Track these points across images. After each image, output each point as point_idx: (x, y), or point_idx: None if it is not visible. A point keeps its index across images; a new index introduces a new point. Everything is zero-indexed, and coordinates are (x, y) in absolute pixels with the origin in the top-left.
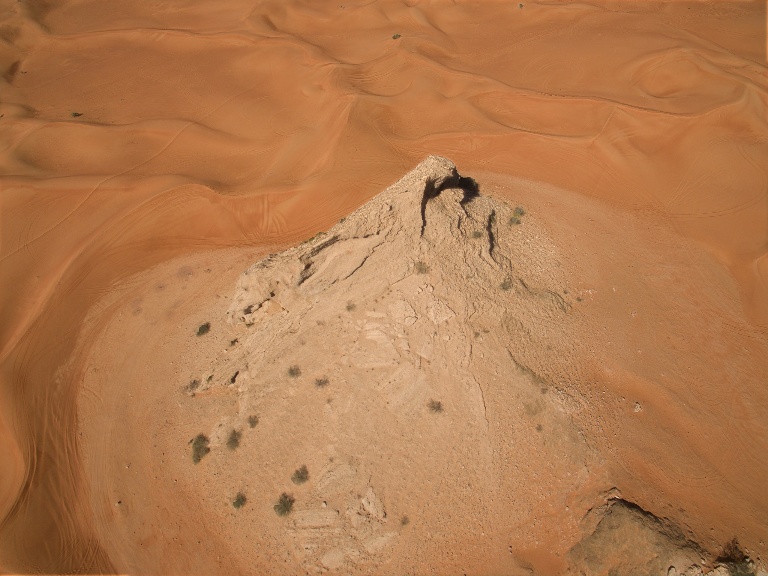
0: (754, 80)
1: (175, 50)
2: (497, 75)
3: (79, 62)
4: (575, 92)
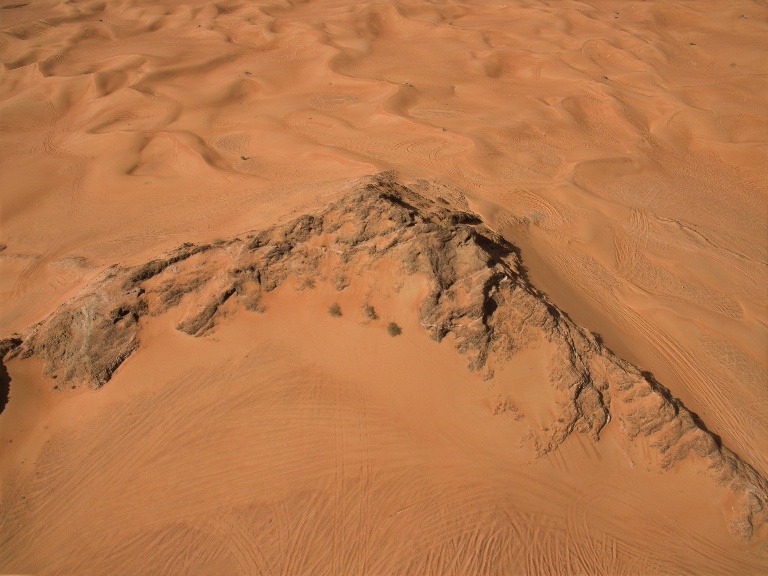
0: (128, 80)
1: (52, 8)
2: (86, 48)
3: (35, 7)
4: (70, 60)
